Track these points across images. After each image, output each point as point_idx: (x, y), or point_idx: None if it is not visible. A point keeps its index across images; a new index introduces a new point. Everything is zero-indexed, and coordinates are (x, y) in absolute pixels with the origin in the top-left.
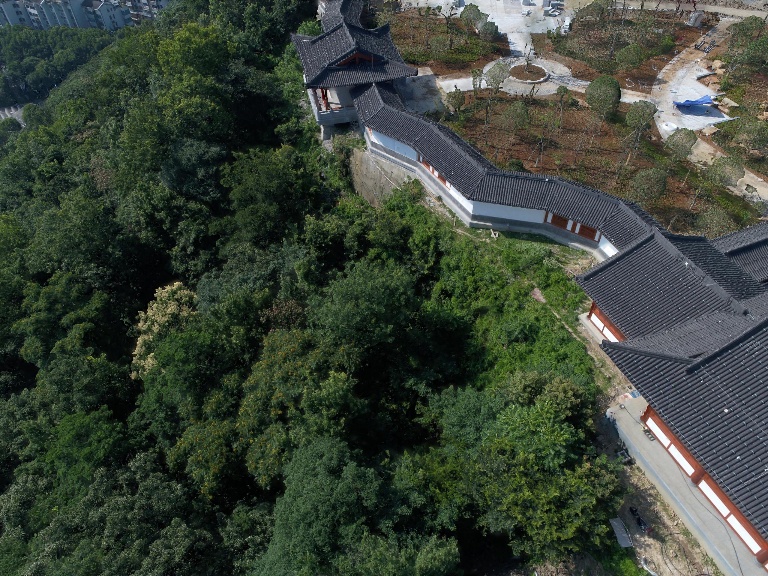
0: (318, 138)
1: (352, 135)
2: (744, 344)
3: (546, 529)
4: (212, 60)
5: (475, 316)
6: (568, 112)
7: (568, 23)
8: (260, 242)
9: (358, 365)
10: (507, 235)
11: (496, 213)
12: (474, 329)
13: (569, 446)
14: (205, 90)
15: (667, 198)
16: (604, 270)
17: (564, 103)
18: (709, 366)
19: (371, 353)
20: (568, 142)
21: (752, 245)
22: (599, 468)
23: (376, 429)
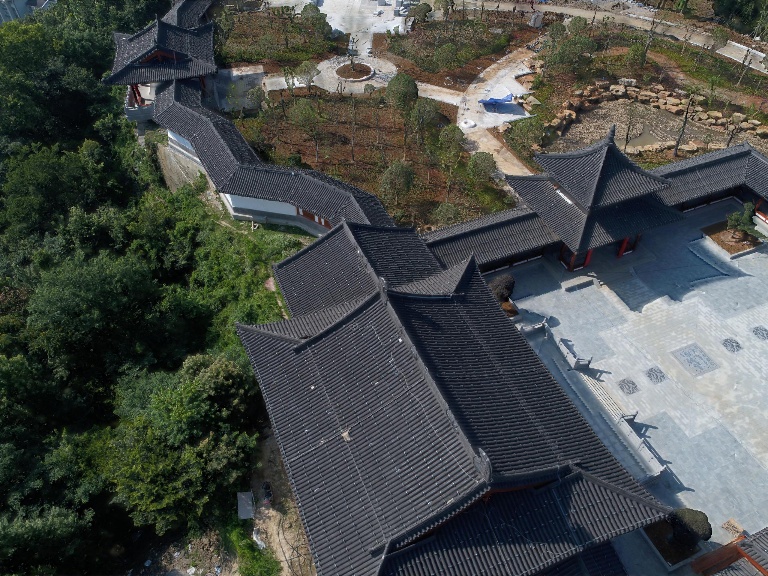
0: (134, 134)
1: (161, 131)
2: (347, 326)
3: (144, 499)
4: (29, 57)
5: (224, 305)
6: (374, 109)
7: (410, 23)
8: (33, 233)
9: (58, 349)
10: (266, 227)
11: (253, 206)
12: (215, 317)
13: (199, 423)
14: (9, 86)
15: (430, 192)
16: (297, 259)
17: (374, 101)
18: (315, 346)
19: (98, 339)
20: (359, 138)
21: (458, 236)
22: (223, 444)
23: (63, 410)
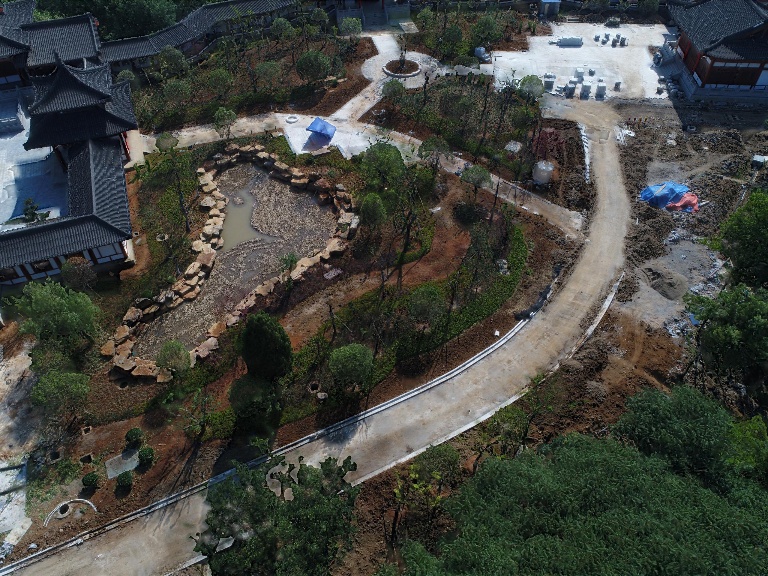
0: None
1: None
2: None
3: None
4: None
5: None
6: None
7: None
8: None
9: (111, 6)
10: None
11: None
12: None
13: None
14: None
15: None
16: None
17: None
18: None
19: None
20: None
21: None
22: None
23: None
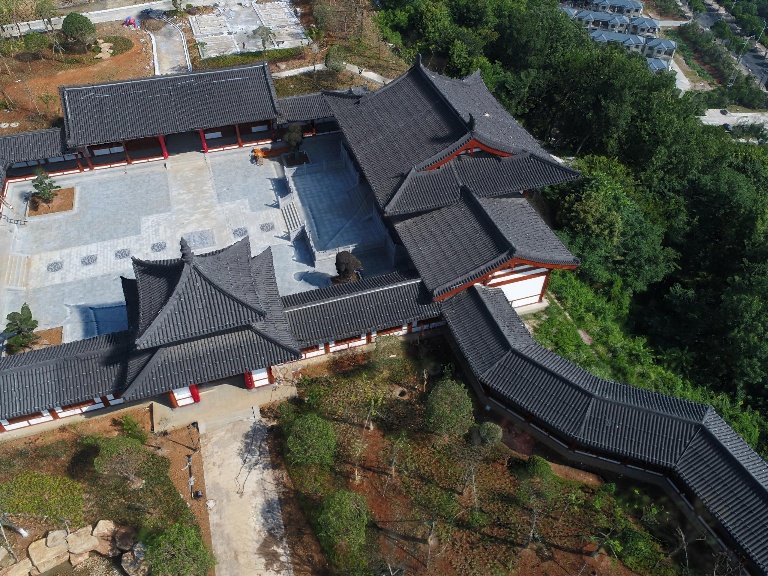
0: None
1: None
2: None
3: None
4: None
5: None
6: None
7: None
8: None
9: None
10: None
11: None
12: None
13: None
14: None
15: None
16: None
17: None
18: None
19: None
20: None
21: None
22: None
23: None
